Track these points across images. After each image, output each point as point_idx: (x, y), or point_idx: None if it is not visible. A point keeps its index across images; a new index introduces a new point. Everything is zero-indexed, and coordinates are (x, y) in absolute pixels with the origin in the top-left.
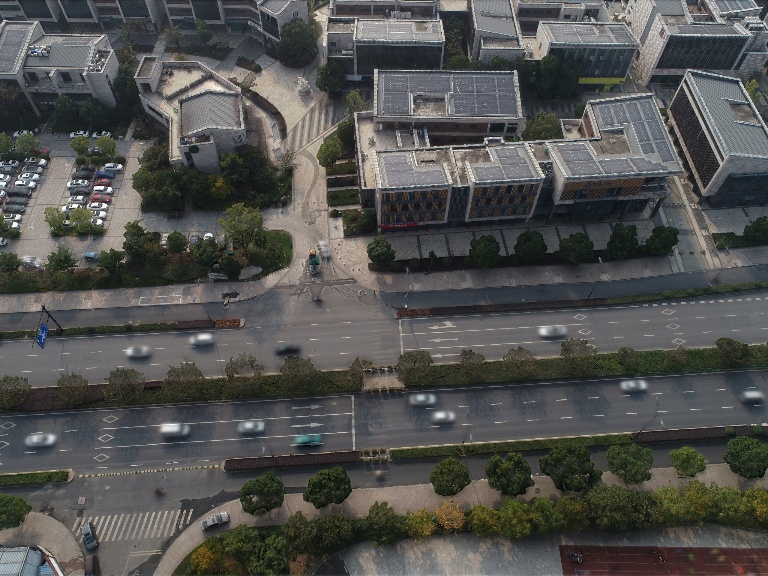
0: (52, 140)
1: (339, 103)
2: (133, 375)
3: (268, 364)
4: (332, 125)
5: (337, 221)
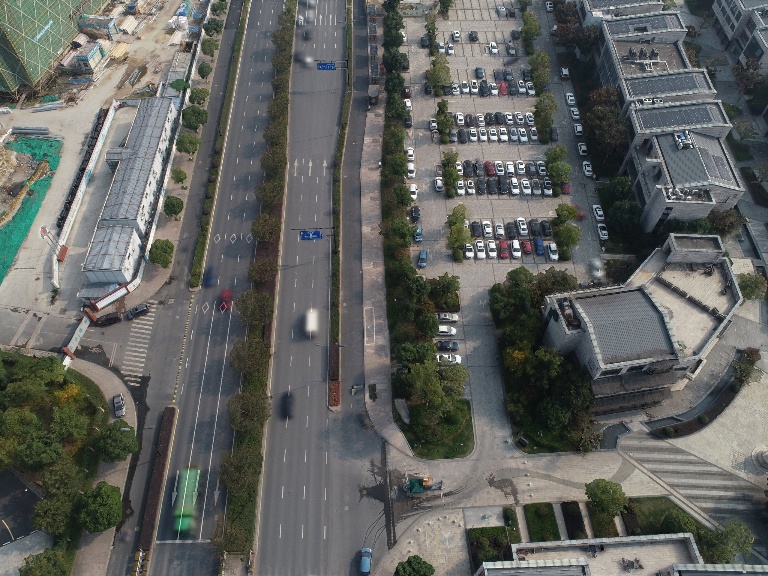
0: (586, 192)
1: (761, 520)
2: (265, 312)
3: (278, 440)
4: (702, 508)
5: (497, 519)
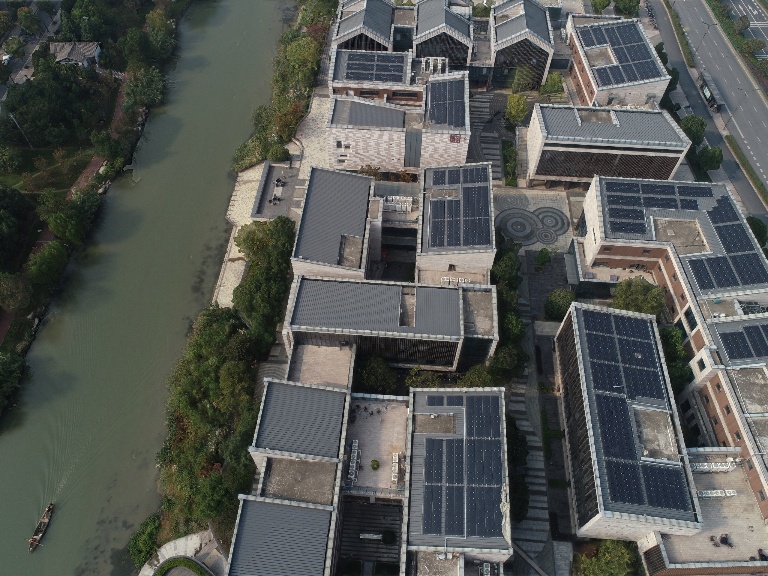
0: None
1: None
2: None
3: None
4: None
5: None
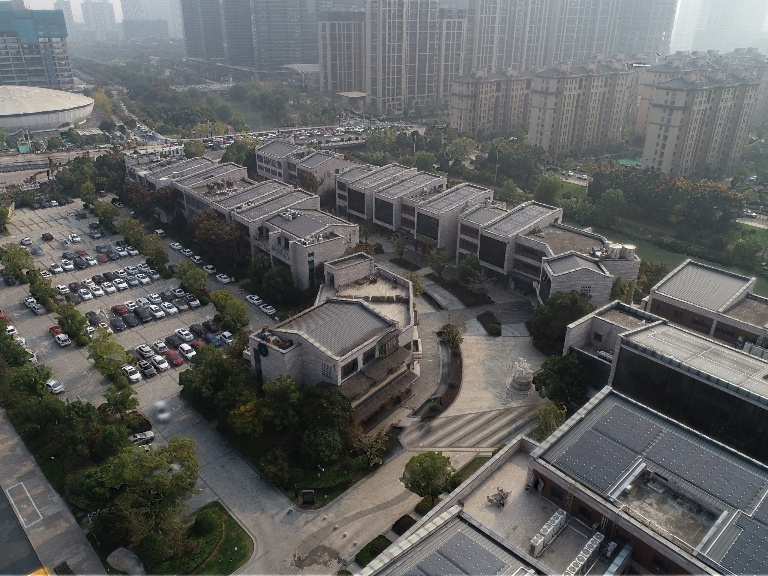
0: (233, 293)
1: None
2: None
3: None
4: None
5: None
